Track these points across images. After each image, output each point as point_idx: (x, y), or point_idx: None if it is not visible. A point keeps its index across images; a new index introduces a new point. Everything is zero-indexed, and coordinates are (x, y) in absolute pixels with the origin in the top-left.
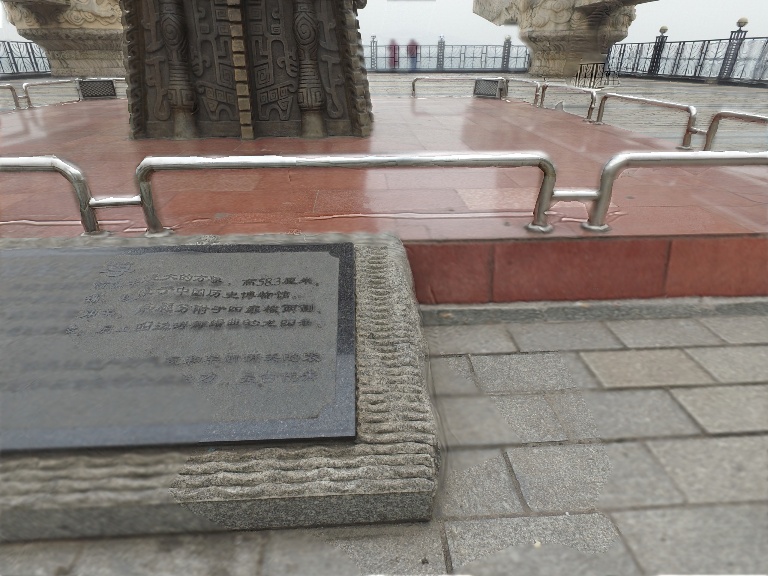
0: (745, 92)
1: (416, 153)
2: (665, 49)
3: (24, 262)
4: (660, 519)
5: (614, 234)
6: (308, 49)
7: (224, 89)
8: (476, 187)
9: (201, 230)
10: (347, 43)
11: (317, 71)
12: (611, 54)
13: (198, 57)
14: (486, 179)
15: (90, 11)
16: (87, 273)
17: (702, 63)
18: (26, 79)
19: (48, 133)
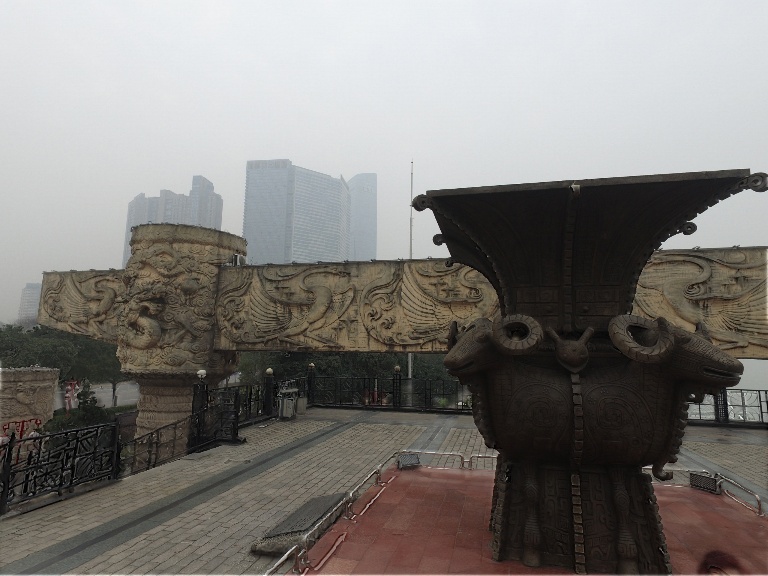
0: None
1: (439, 567)
2: None
3: None
4: (228, 569)
5: (289, 572)
6: None
7: None
8: (359, 565)
9: None
10: None
11: None
12: None
13: None
14: (370, 571)
15: None
16: None
17: None
18: None
19: None
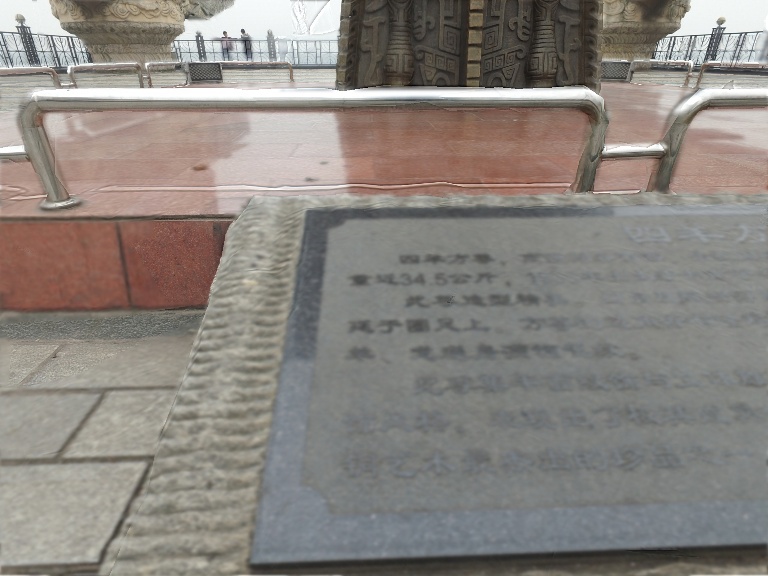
0: None
1: (699, 123)
2: (723, 41)
3: (651, 222)
4: None
5: None
6: (551, 7)
7: (445, 55)
8: None
9: (698, 193)
10: (595, 0)
11: (554, 34)
12: (658, 47)
13: (422, 18)
14: None
15: (135, 4)
16: (767, 237)
17: None
18: None
19: None
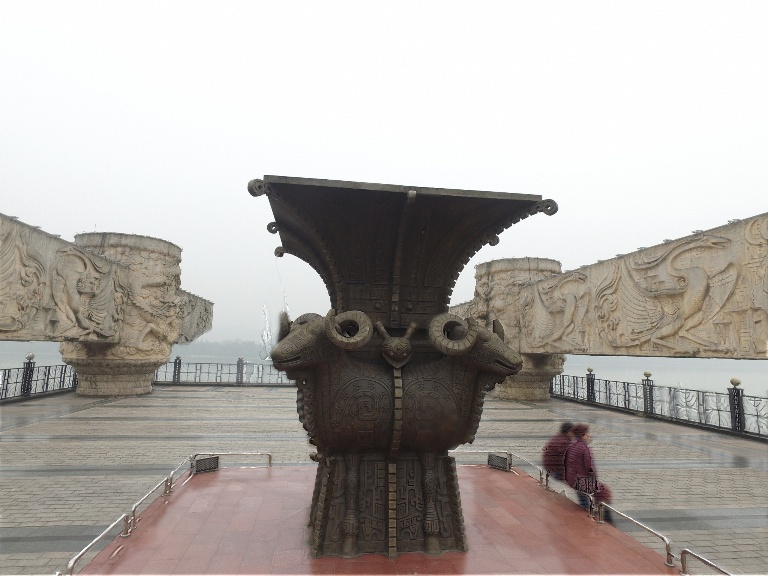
0: (671, 435)
1: None
2: (596, 384)
3: None
4: None
5: None
6: (432, 496)
7: (377, 520)
8: None
9: None
10: (455, 492)
11: (436, 508)
12: (553, 381)
13: (363, 500)
14: None
15: (135, 347)
16: None
17: (628, 399)
18: (52, 397)
19: (241, 545)
